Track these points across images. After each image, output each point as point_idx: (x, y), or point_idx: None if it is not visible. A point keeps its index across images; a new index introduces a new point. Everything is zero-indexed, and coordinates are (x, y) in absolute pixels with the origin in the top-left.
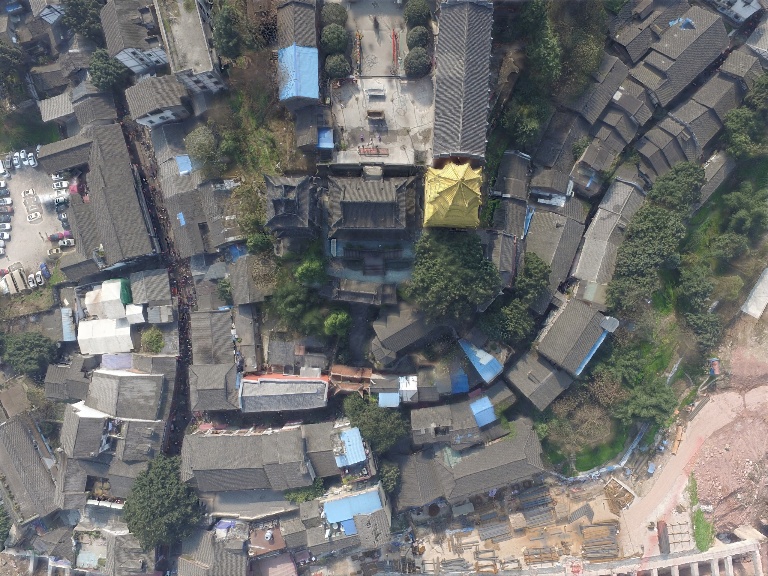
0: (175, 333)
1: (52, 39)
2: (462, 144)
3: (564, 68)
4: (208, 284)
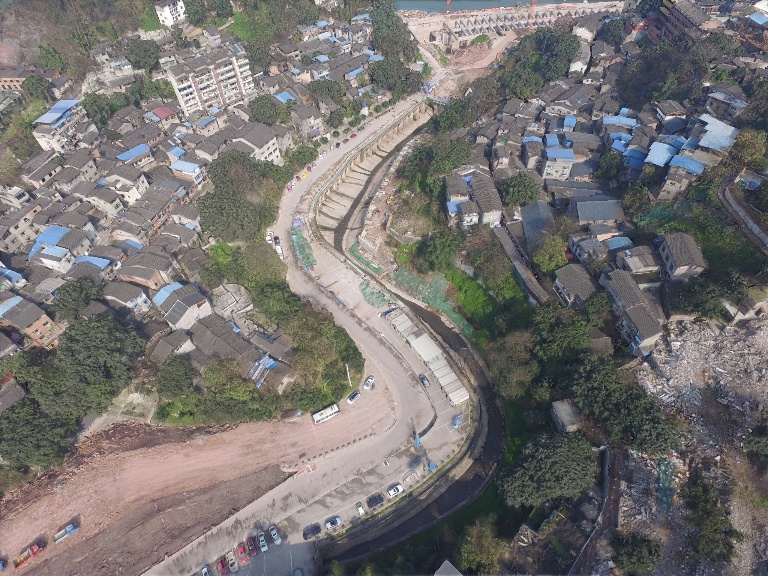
0: None
1: None
2: (687, 0)
3: (645, 55)
4: None
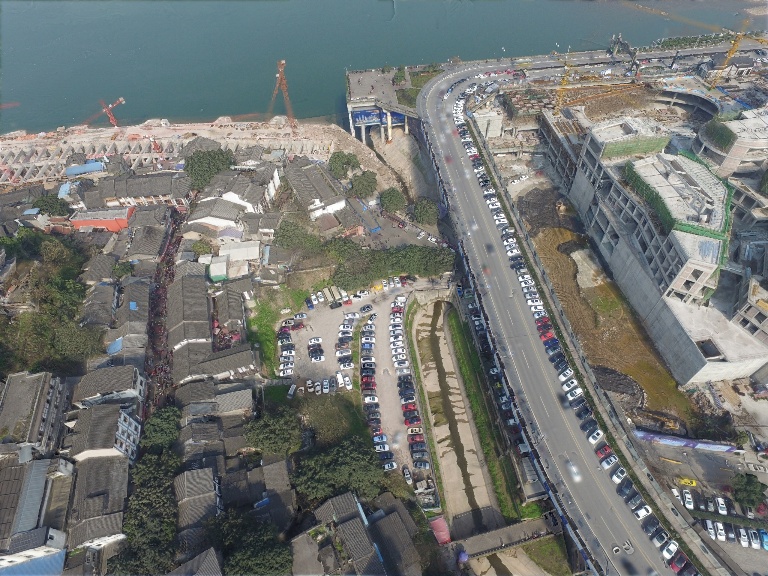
0: (181, 250)
1: (221, 464)
2: None
3: None
4: (140, 275)
